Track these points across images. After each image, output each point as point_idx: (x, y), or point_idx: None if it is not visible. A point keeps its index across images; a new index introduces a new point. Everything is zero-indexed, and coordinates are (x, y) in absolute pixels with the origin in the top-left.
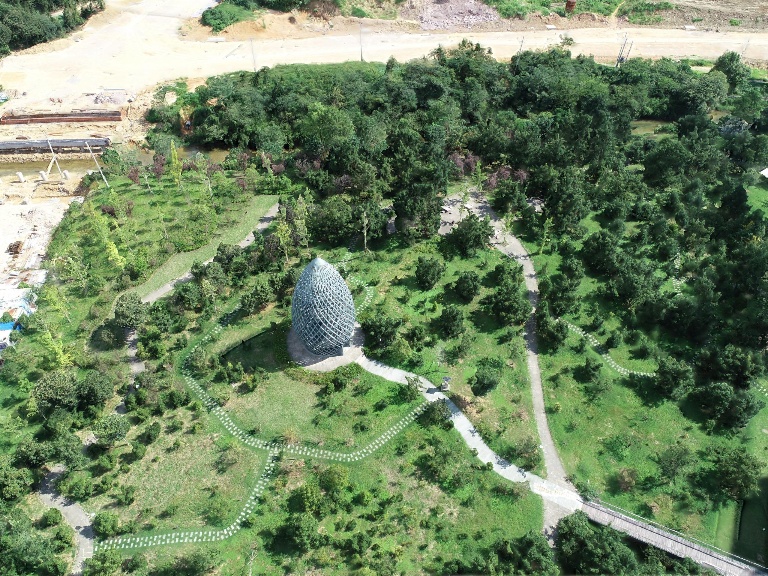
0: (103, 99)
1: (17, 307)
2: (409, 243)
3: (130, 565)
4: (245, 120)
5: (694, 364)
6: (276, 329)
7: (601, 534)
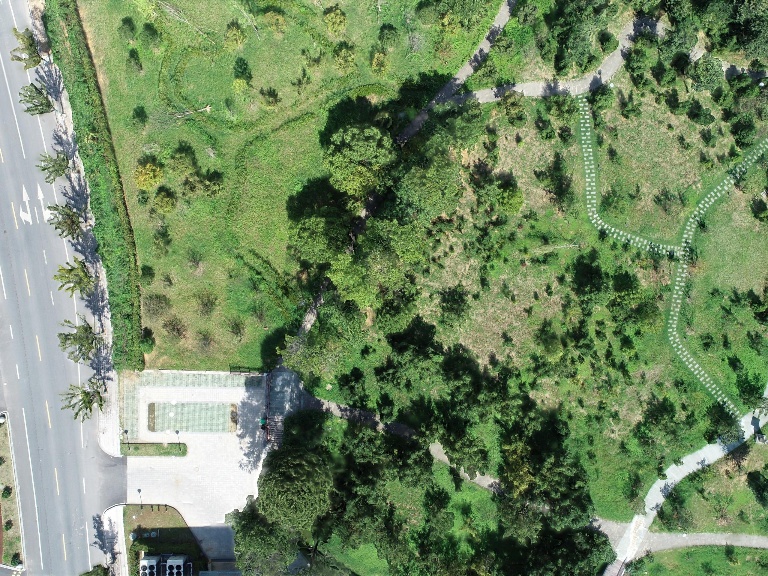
0: None
1: None
2: None
3: (565, 134)
4: None
5: None
6: None
7: (593, 575)
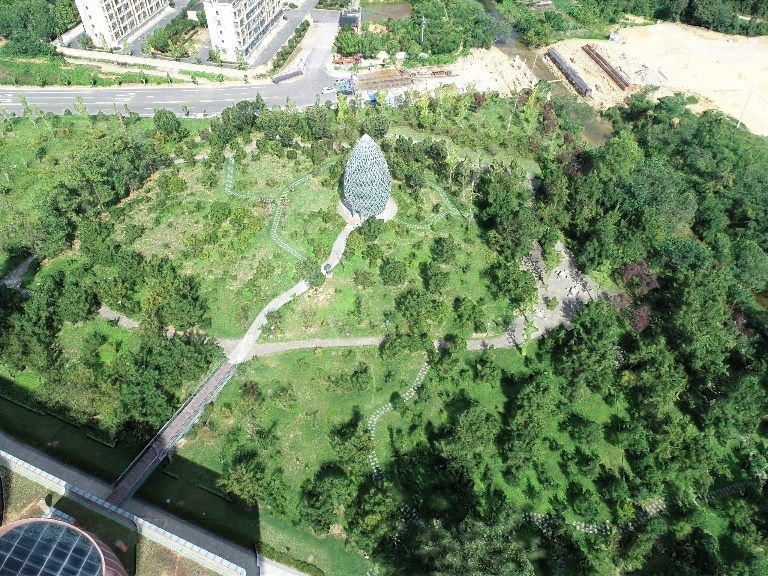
0: (643, 73)
1: (388, 96)
2: (490, 244)
3: None
4: (652, 139)
5: None
6: None
7: None
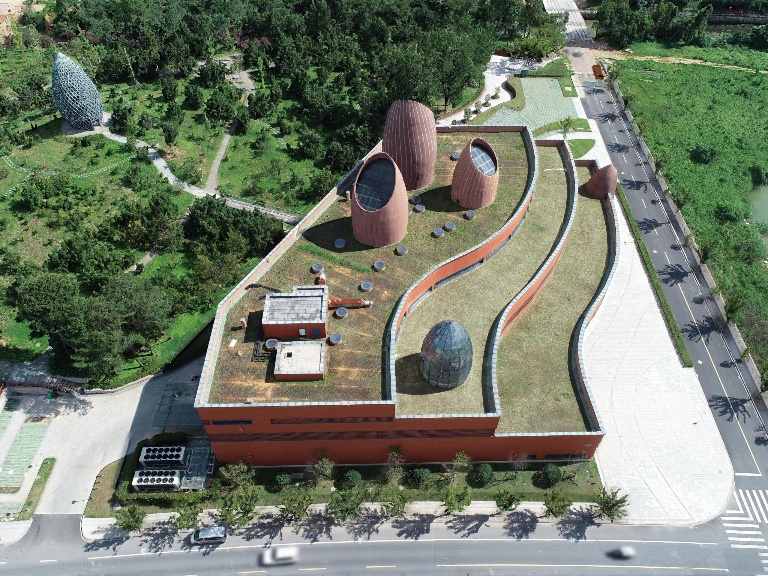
0: None
1: None
2: (168, 79)
3: None
4: (89, 19)
5: None
6: (57, 119)
7: None
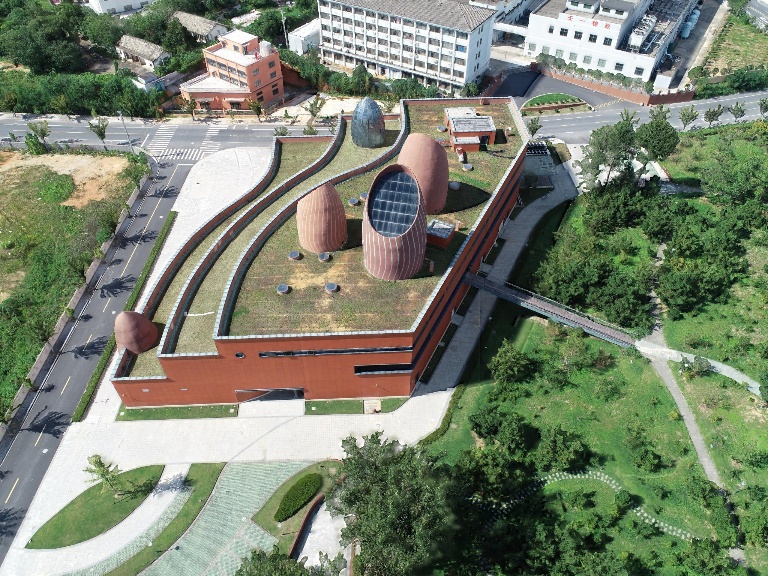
0: None
1: None
2: None
3: None
4: None
5: (512, 500)
6: None
7: None
